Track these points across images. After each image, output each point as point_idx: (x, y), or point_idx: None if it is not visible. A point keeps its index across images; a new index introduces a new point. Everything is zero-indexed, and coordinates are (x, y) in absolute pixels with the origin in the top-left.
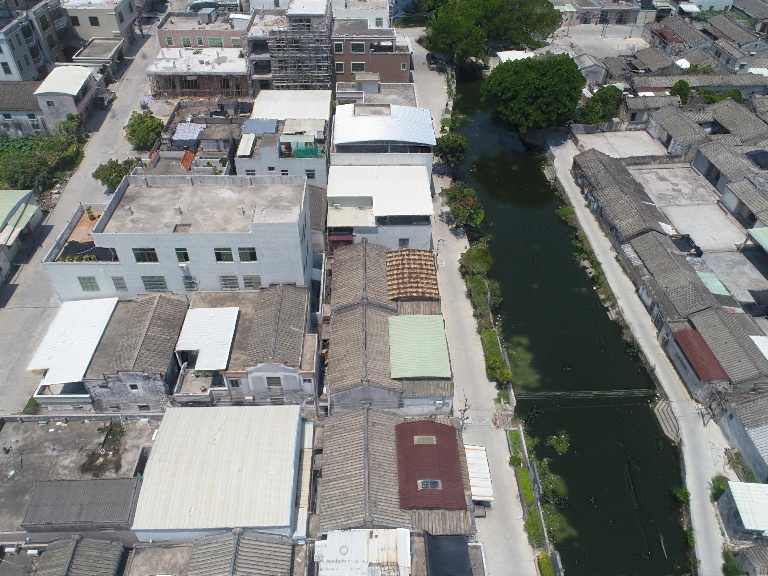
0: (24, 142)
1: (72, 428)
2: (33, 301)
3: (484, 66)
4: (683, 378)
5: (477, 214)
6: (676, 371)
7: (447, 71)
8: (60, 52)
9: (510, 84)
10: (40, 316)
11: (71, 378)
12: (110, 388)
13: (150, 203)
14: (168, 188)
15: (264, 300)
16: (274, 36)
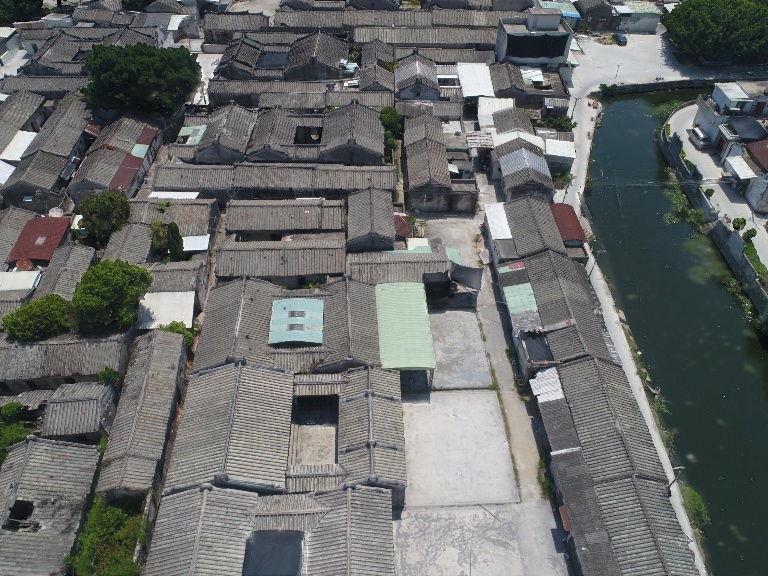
0: None
1: None
2: None
3: None
4: None
5: None
6: None
7: None
8: None
9: None
10: None
11: None
12: None
13: None
14: None
15: None
16: None
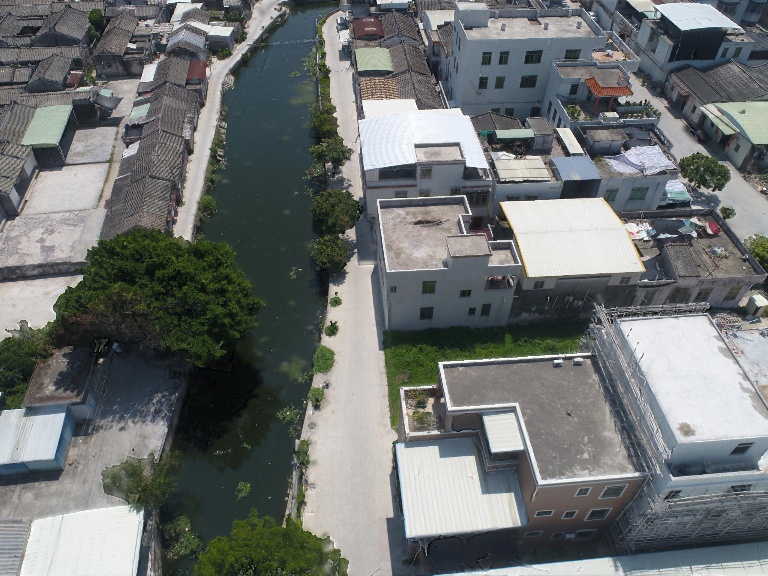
0: None
1: None
2: None
3: None
4: None
5: None
6: None
7: None
8: None
9: None
10: None
11: None
12: None
13: (573, 34)
14: None
15: None
16: None
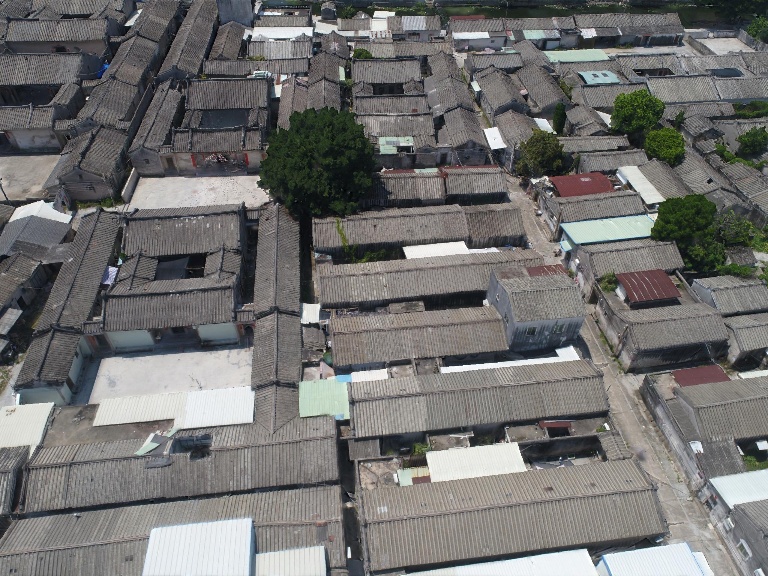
0: None
1: None
2: None
3: None
4: None
5: None
6: None
7: None
8: None
9: None
10: None
11: None
12: None
13: None
14: None
15: None
16: None
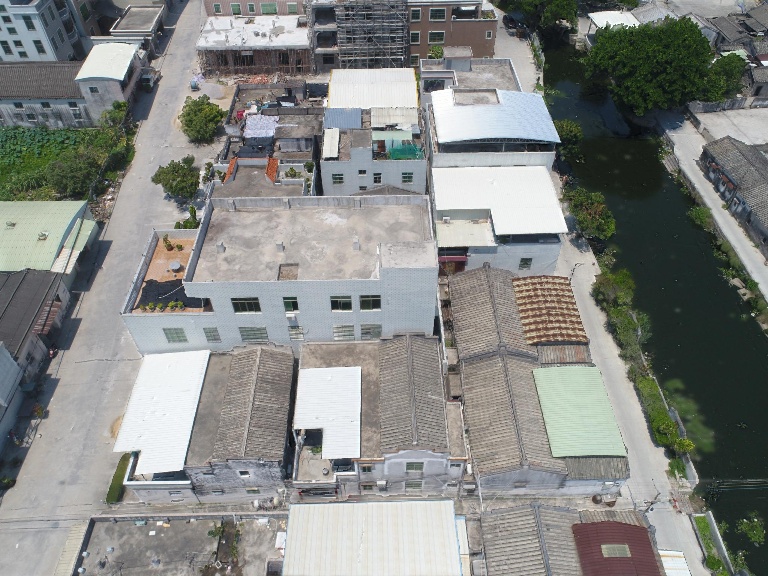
0: (66, 134)
1: (176, 530)
2: (101, 341)
3: (571, 29)
4: None
5: (607, 224)
6: None
7: (530, 36)
8: (94, 23)
9: (626, 58)
10: (111, 361)
11: (170, 466)
12: (215, 474)
13: (243, 234)
14: (261, 213)
15: (389, 356)
16: (342, 3)
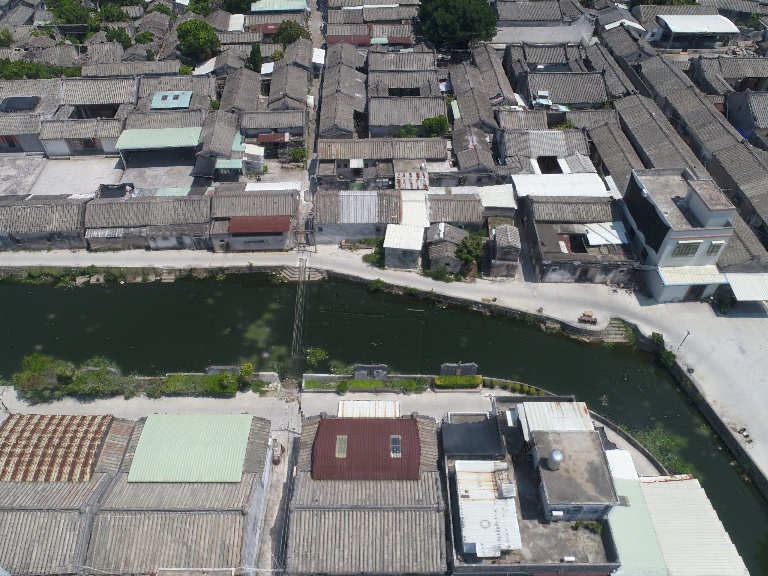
0: None
1: None
2: None
3: None
4: (267, 249)
5: None
6: (257, 252)
7: None
8: None
9: None
10: None
11: None
12: None
13: None
14: None
15: None
16: None
